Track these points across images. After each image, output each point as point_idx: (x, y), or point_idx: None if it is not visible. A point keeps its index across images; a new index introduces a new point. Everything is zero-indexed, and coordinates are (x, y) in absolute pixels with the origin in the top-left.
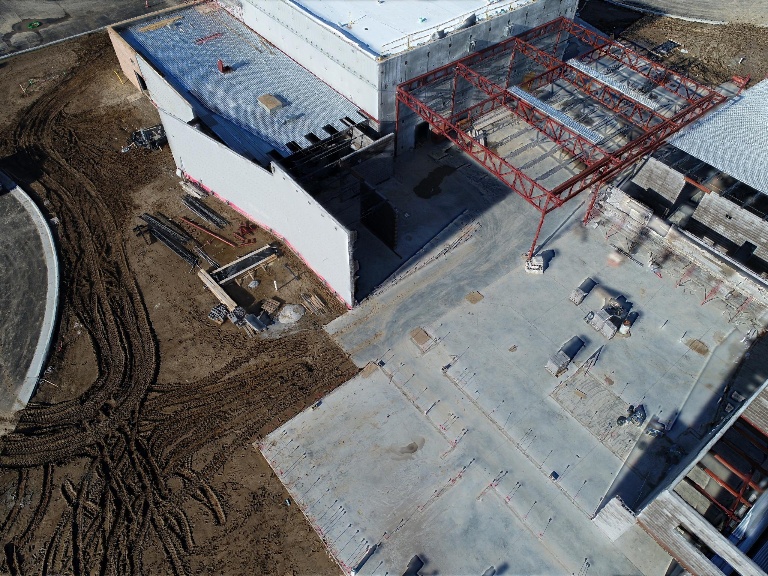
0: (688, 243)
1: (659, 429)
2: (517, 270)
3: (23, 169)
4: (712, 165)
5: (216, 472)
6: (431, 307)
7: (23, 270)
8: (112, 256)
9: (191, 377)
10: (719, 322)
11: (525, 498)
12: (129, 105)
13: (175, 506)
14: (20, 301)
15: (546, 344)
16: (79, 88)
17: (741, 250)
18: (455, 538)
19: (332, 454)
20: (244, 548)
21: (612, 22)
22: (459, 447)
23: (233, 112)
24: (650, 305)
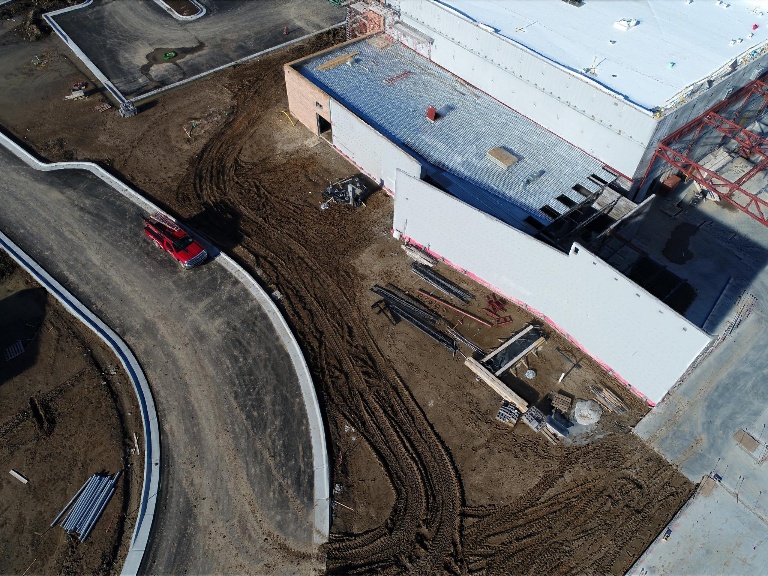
0: None
1: None
2: None
3: (219, 230)
4: None
5: None
6: (744, 403)
7: (263, 358)
8: (357, 339)
9: (504, 497)
10: None
11: None
12: (310, 151)
13: None
14: (273, 398)
15: None
16: (246, 131)
17: None
18: None
19: None
20: None
21: None
22: None
23: (464, 169)
24: None
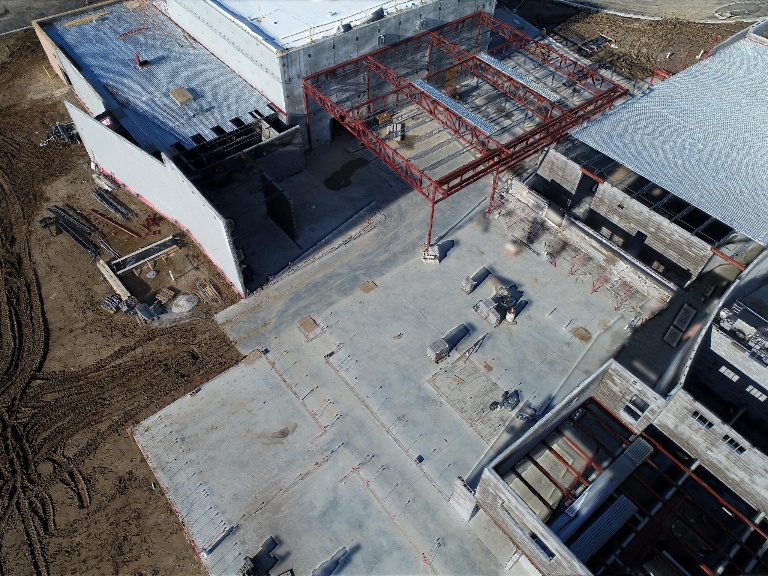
0: (577, 232)
1: (530, 414)
2: (414, 260)
3: None
4: (609, 156)
5: (87, 457)
6: (323, 296)
7: None
8: (16, 247)
9: (76, 365)
10: (606, 310)
11: (387, 481)
12: (54, 100)
13: (42, 490)
14: None
15: (432, 332)
16: (7, 83)
17: (639, 240)
18: (312, 520)
19: (203, 439)
20: (104, 530)
21: (547, 18)
22: (330, 432)
23: (144, 105)
24: (540, 294)
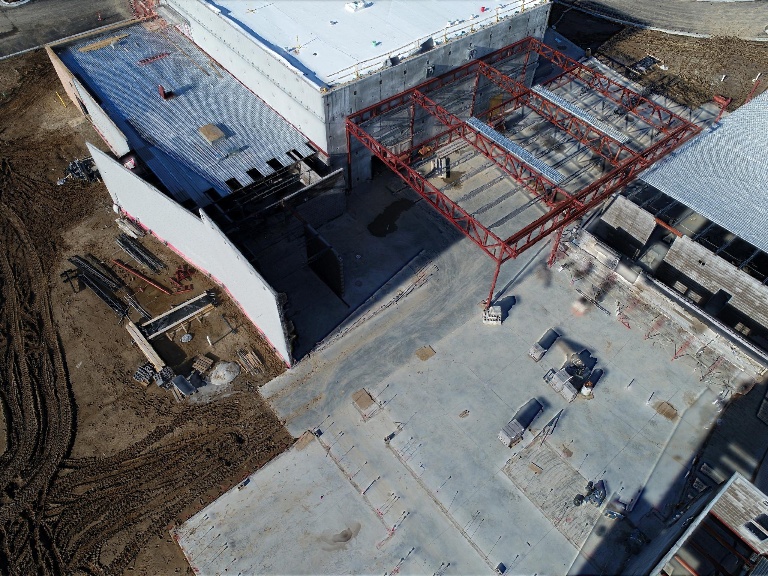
0: (657, 294)
1: (619, 510)
2: (474, 320)
3: None
4: (685, 204)
5: (126, 566)
6: (378, 365)
7: None
8: (35, 306)
9: (109, 450)
10: (690, 380)
11: None
12: (70, 131)
13: None
14: None
15: (500, 408)
16: (18, 111)
17: (716, 295)
18: None
19: (256, 544)
20: None
21: (590, 35)
22: (398, 534)
23: (172, 144)
24: (616, 361)
